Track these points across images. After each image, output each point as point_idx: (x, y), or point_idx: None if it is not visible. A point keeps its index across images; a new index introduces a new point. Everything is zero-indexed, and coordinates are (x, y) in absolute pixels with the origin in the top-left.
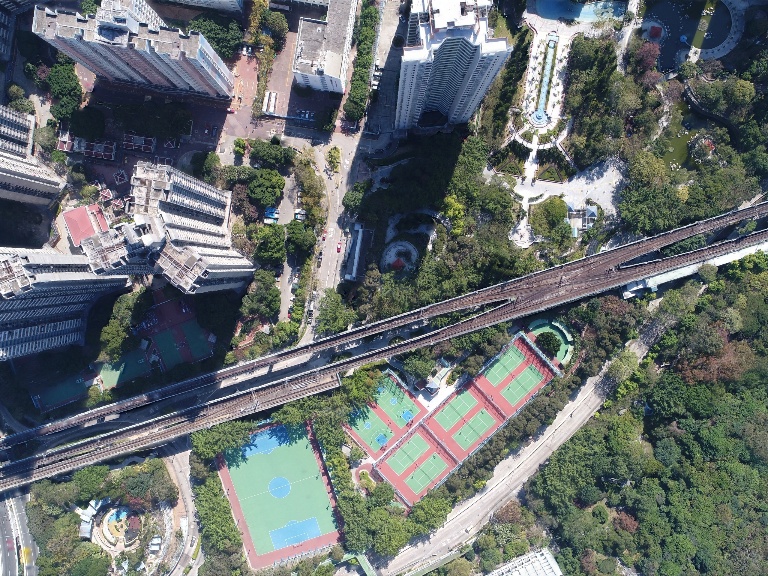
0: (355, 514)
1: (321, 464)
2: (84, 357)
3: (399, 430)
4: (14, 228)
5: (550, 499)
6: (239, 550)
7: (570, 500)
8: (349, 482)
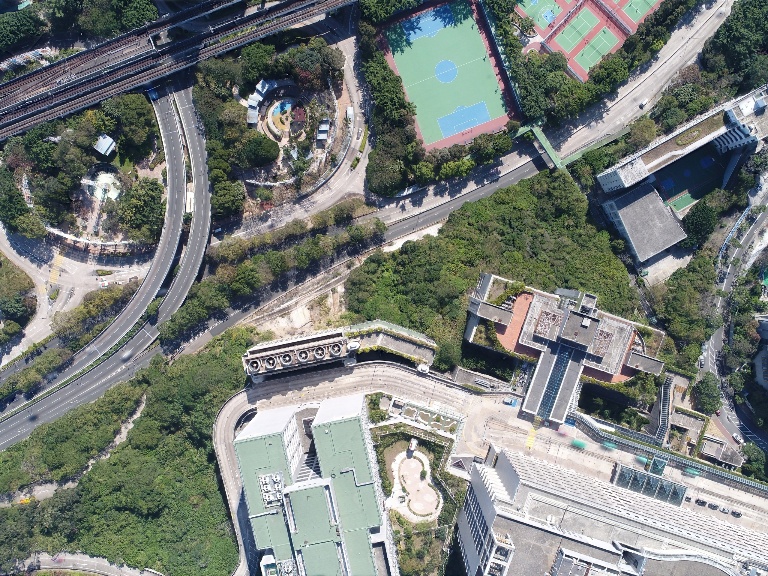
0: (532, 76)
1: (488, 45)
2: None
3: (567, 5)
4: None
5: (734, 49)
6: (413, 123)
7: (756, 47)
8: (521, 53)
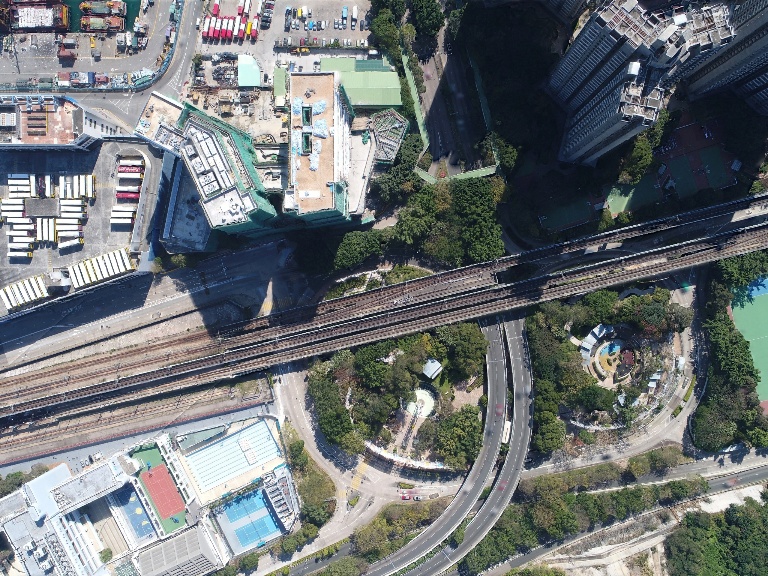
0: None
1: None
2: (597, 178)
3: None
4: (544, 37)
5: None
6: (755, 389)
7: None
8: None
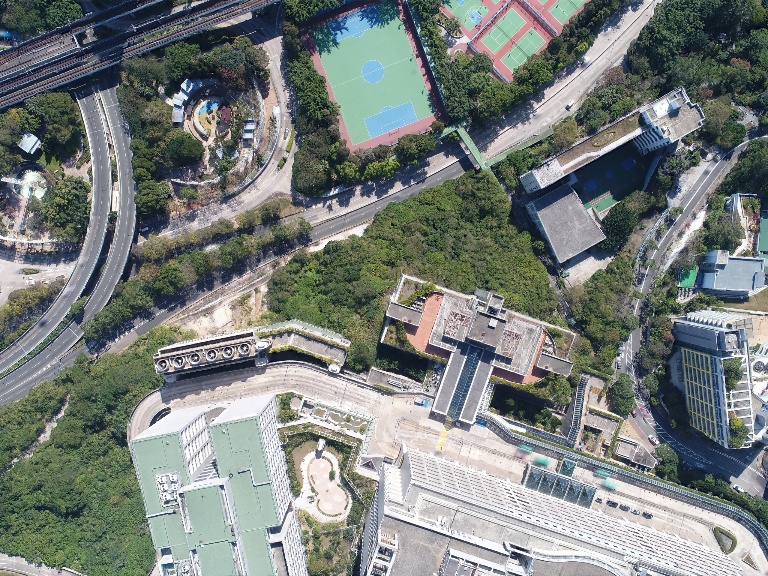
0: (455, 77)
1: (414, 45)
2: None
3: (493, 6)
4: None
5: (657, 51)
6: (337, 123)
7: (678, 49)
8: (446, 54)
